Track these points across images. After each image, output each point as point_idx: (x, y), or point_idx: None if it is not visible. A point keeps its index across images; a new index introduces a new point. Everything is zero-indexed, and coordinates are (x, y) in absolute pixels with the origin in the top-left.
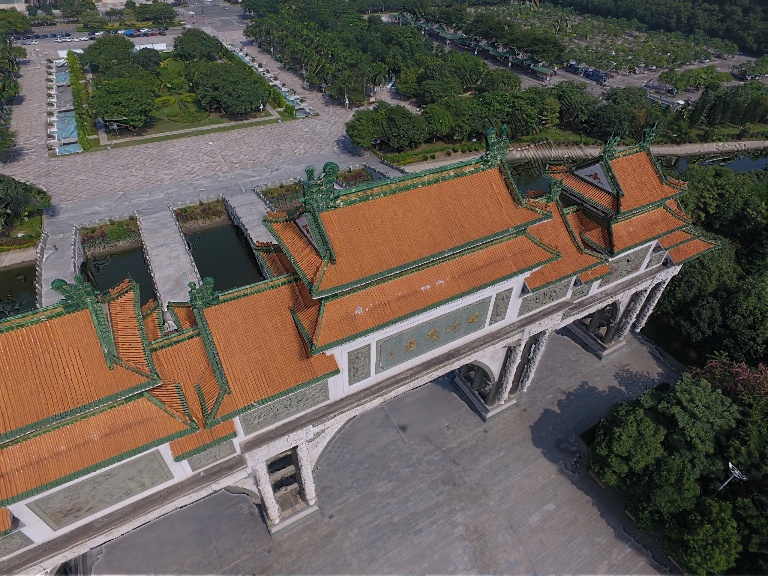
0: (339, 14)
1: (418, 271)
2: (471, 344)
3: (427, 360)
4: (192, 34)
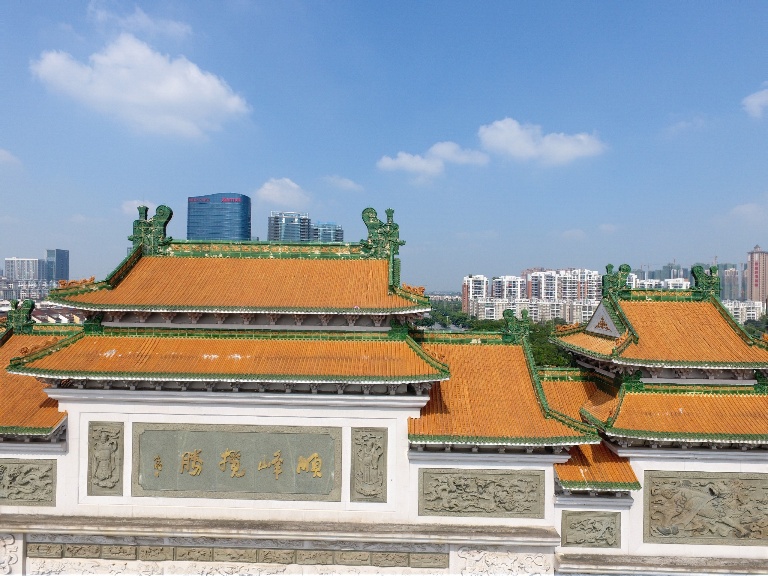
0: None
1: (218, 338)
2: (310, 524)
3: (226, 518)
4: None
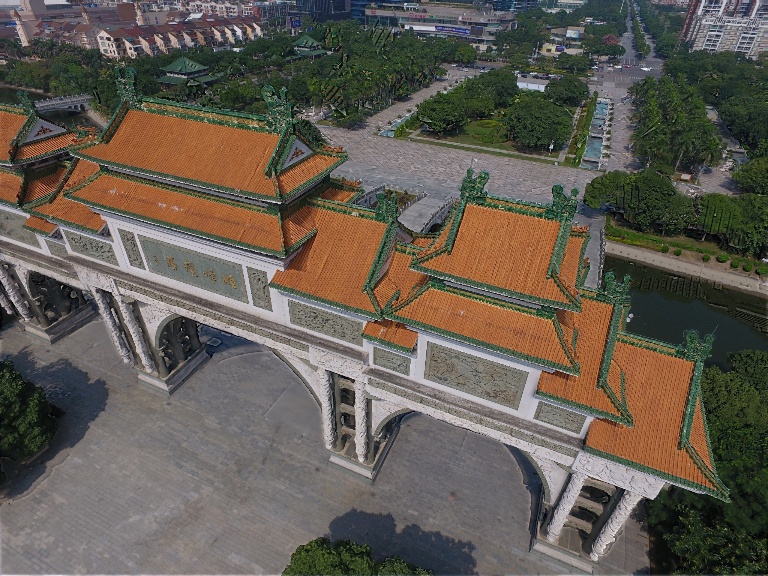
0: (762, 90)
1: (169, 190)
2: (234, 311)
3: (195, 295)
4: (567, 80)
